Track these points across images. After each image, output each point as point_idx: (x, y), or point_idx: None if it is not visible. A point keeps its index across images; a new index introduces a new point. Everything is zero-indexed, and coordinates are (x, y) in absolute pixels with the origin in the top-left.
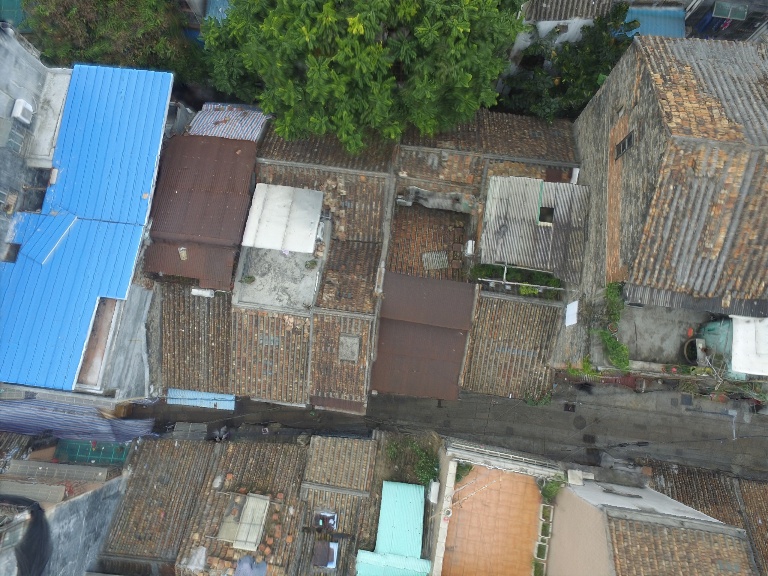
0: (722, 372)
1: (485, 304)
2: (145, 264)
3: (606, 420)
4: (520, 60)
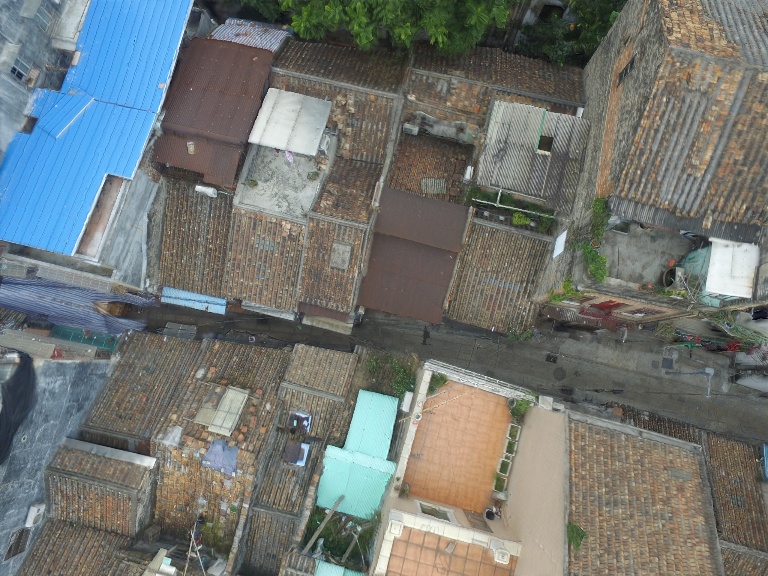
0: (696, 293)
1: (477, 232)
2: (154, 154)
3: (586, 374)
4: (540, 11)
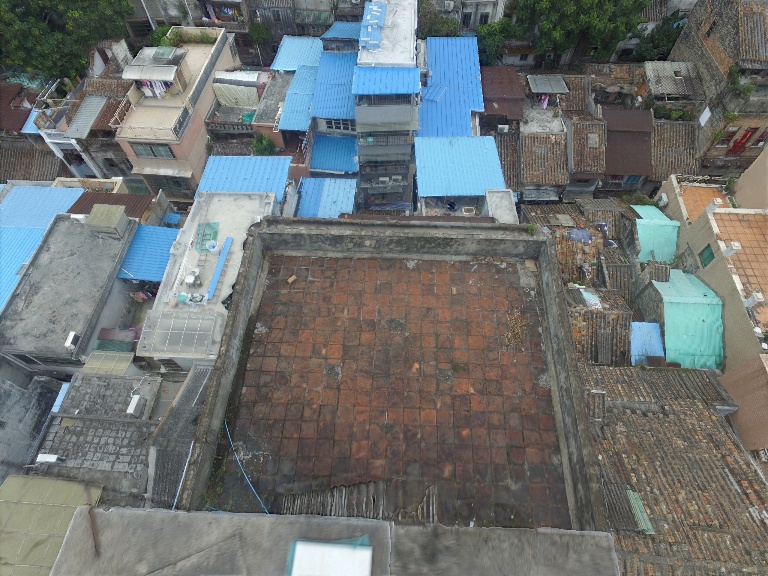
0: None
1: None
2: None
3: None
4: (620, 53)
